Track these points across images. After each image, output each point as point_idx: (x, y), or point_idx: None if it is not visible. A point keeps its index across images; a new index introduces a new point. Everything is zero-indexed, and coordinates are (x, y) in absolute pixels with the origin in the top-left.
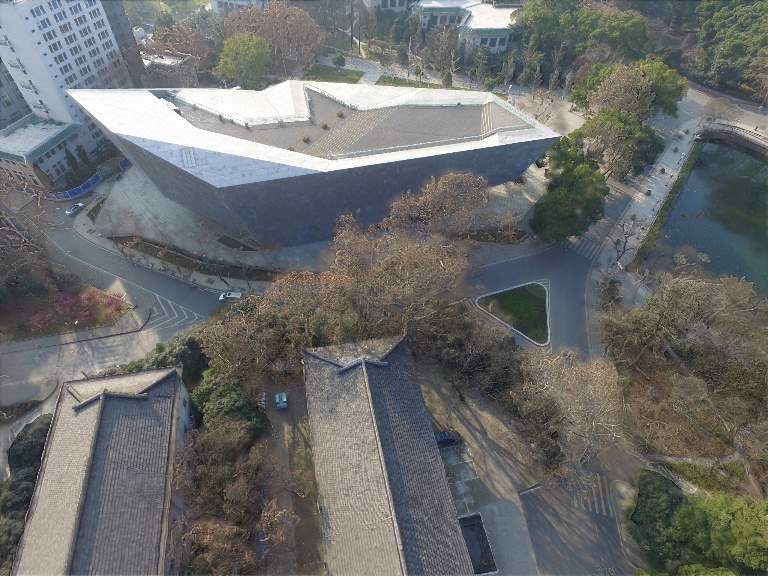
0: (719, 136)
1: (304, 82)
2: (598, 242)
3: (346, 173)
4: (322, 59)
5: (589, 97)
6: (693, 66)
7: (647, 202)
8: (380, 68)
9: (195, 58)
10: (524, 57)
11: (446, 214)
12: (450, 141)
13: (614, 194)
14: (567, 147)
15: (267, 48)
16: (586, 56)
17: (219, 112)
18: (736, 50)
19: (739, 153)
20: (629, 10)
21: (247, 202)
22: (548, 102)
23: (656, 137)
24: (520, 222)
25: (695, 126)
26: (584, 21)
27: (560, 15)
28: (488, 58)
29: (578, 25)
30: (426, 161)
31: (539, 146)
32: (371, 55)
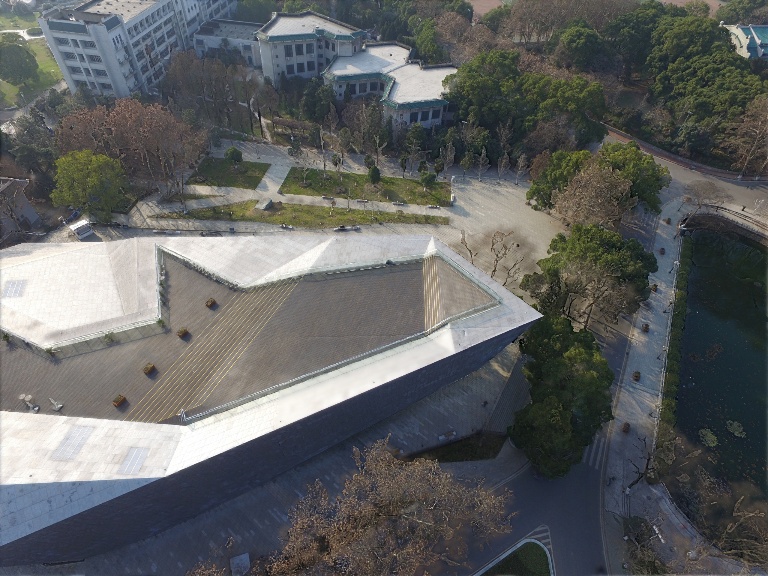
0: (707, 226)
1: (158, 241)
2: (601, 431)
3: (206, 462)
4: (215, 148)
5: (554, 199)
6: (657, 130)
7: (648, 344)
8: (290, 156)
9: (21, 182)
10: (464, 135)
11: (382, 568)
12: (380, 346)
13: (604, 336)
14: (540, 285)
15: (118, 168)
16: (538, 133)
17: (3, 330)
18: (701, 108)
19: (728, 239)
20: (581, 73)
21: (22, 553)
22: (500, 192)
23: (647, 255)
24: (493, 418)
25: (675, 211)
26: (530, 89)
27: (501, 81)
28: (421, 139)
29: (524, 93)
30: (344, 404)
31: (512, 334)
32: (278, 137)
